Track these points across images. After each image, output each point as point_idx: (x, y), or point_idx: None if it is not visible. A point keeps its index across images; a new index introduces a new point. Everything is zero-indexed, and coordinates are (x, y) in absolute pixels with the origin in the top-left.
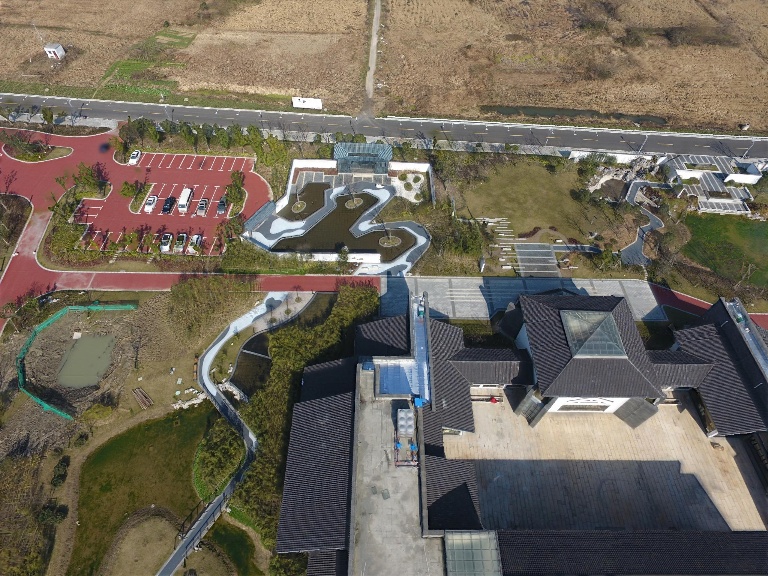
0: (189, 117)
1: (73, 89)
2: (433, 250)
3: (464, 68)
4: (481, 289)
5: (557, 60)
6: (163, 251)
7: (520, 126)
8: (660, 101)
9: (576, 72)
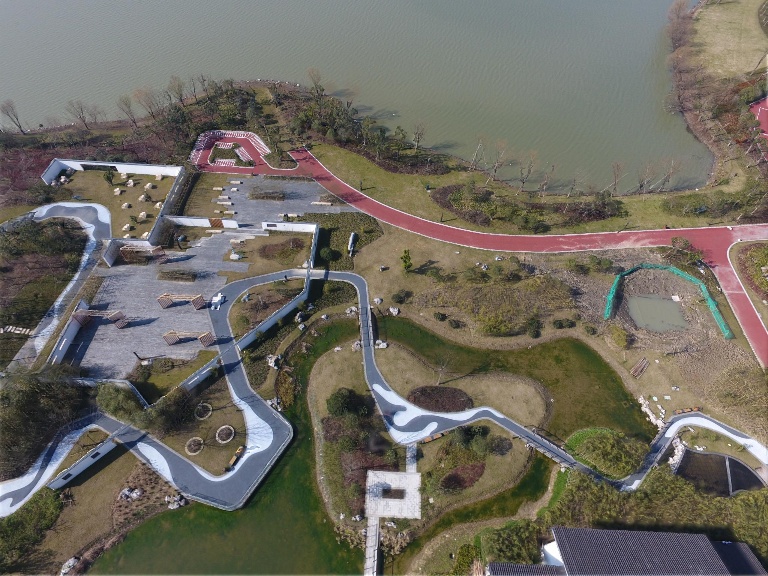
0: None
1: None
2: None
3: None
4: None
5: None
6: None
7: None
8: None
9: None
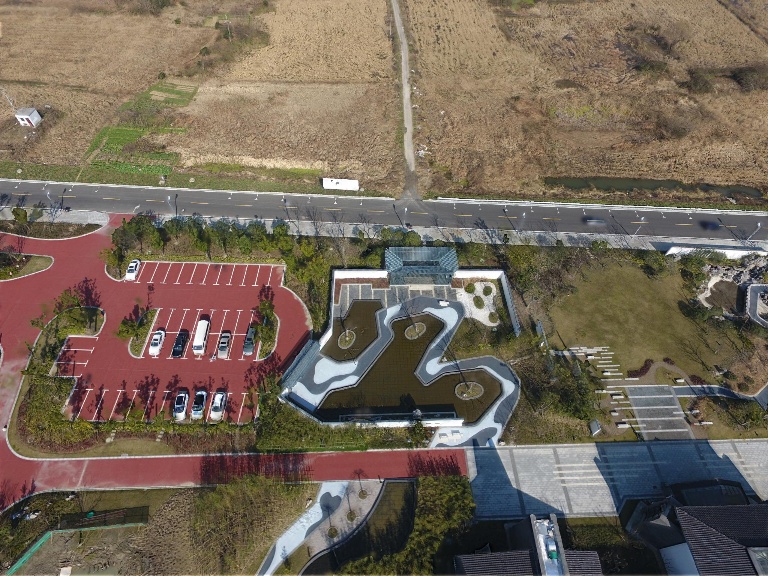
0: (197, 205)
1: (52, 169)
2: (526, 403)
3: (516, 127)
4: (597, 463)
5: (620, 113)
6: (177, 420)
7: (597, 207)
8: (748, 165)
9: (644, 128)
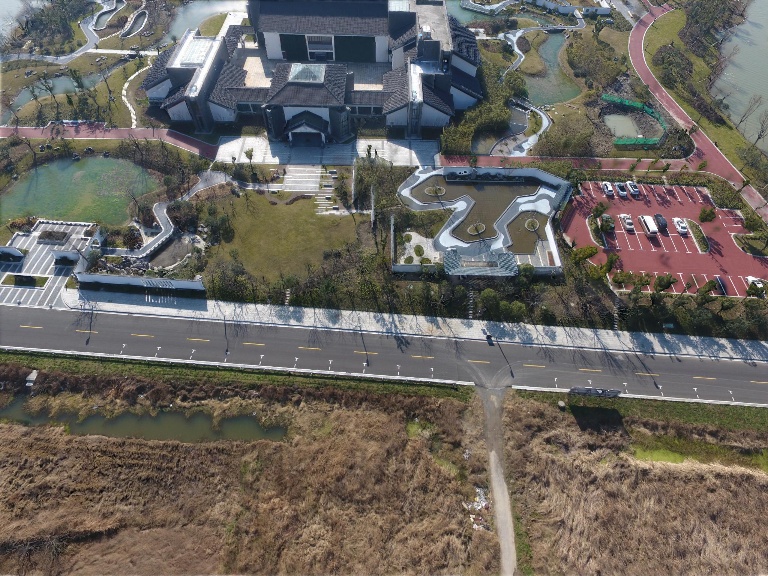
0: (763, 378)
1: None
2: (396, 182)
3: None
4: None
5: None
6: None
7: None
8: None
9: None
